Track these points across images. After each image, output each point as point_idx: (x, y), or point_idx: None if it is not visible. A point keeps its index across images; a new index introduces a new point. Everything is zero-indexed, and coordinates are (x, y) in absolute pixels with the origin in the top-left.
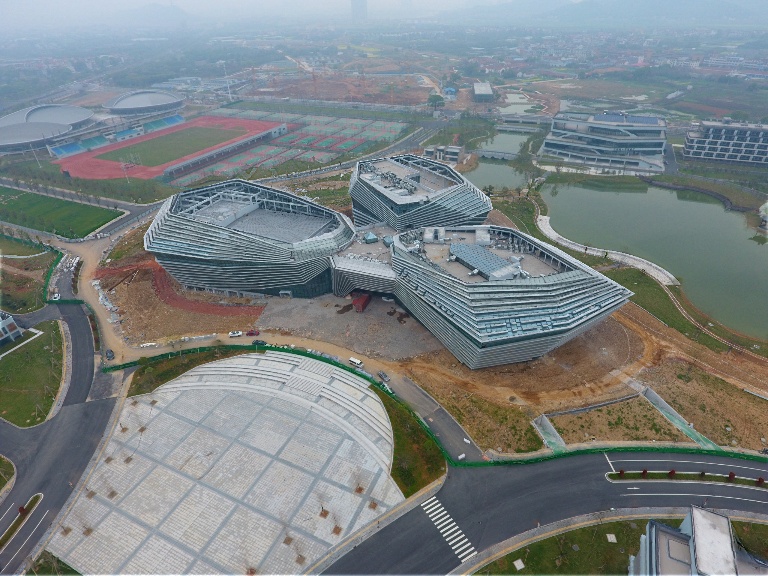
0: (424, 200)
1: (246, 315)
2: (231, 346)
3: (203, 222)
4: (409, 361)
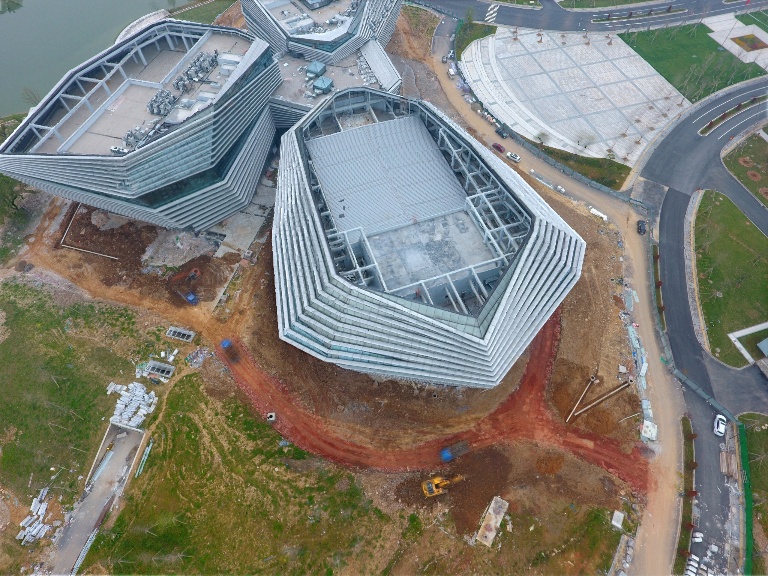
0: None
1: None
2: None
3: (498, 172)
4: (416, 59)
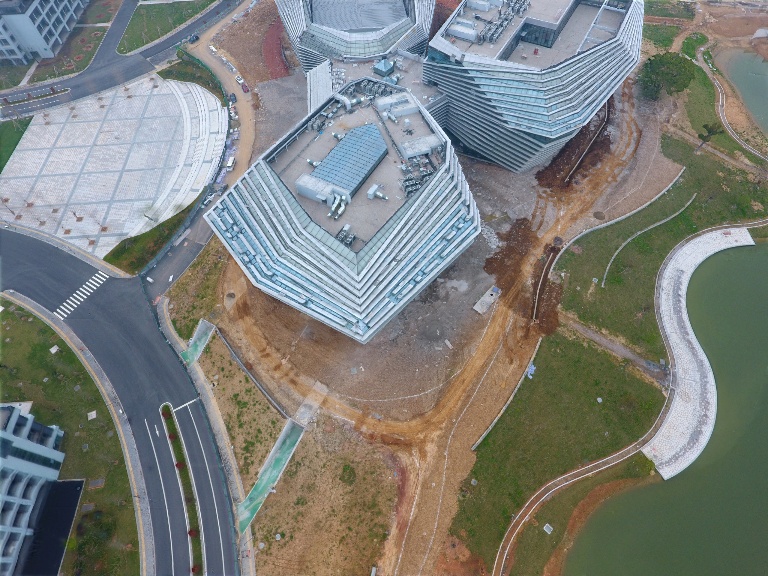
0: (457, 58)
1: (269, 72)
2: (219, 85)
3: None
4: None
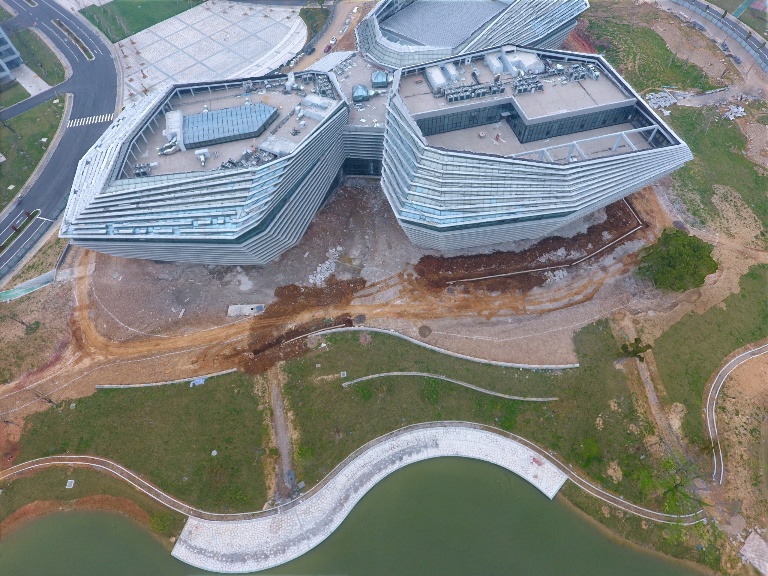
0: None
1: None
2: None
3: None
4: None
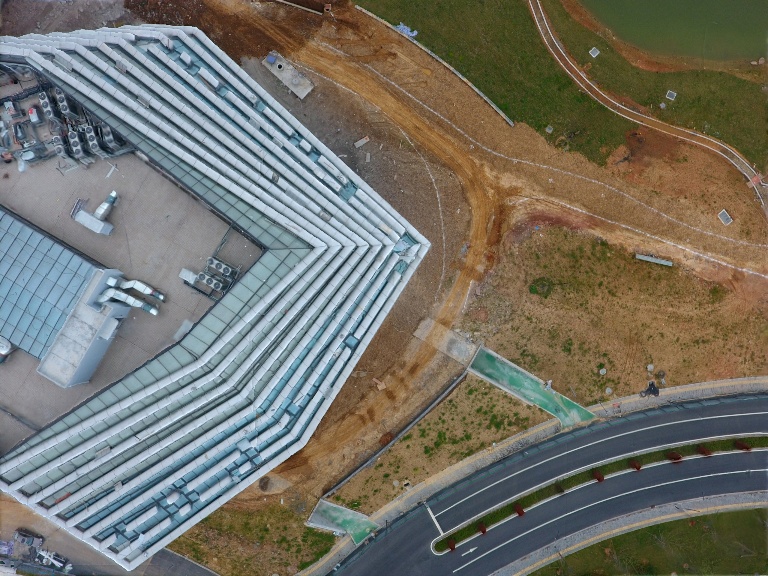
0: None
1: None
2: None
3: None
4: None
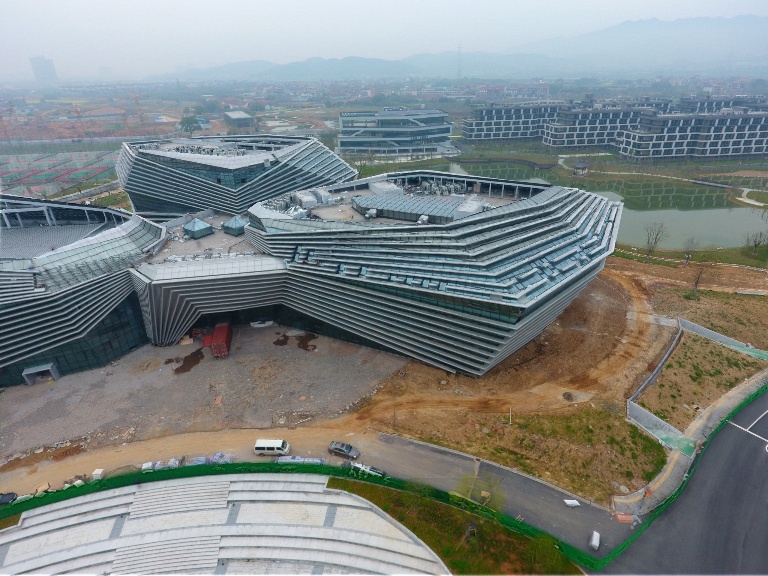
0: (270, 160)
1: None
2: None
3: None
4: (368, 404)
